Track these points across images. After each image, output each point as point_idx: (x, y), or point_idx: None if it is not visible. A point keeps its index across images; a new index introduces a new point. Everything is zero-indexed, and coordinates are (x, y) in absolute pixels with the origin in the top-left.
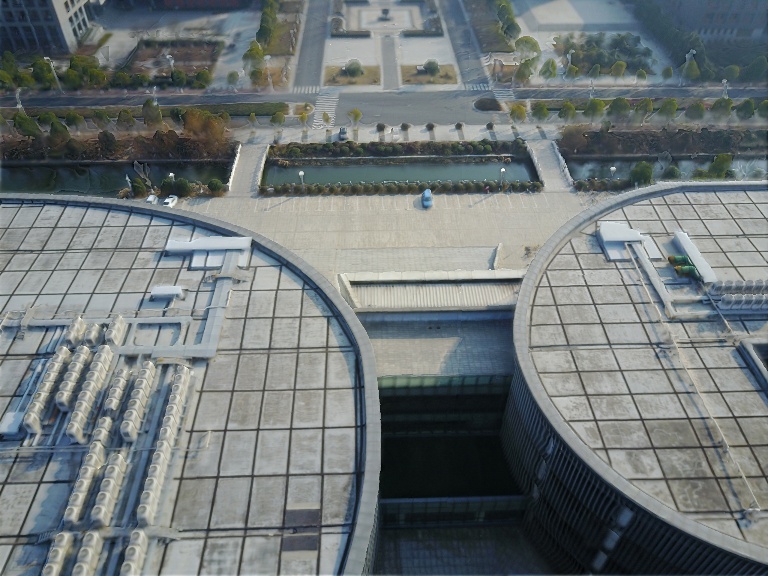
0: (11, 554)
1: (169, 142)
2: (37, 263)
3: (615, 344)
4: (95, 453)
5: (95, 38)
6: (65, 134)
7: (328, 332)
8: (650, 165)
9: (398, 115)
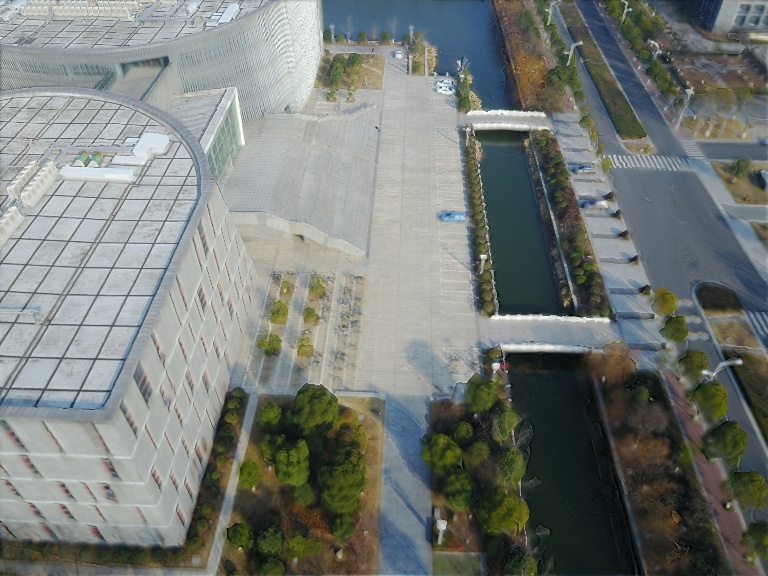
0: None
1: (524, 75)
2: None
3: None
4: None
5: (755, 37)
6: (532, 39)
7: None
8: (481, 389)
9: (651, 212)
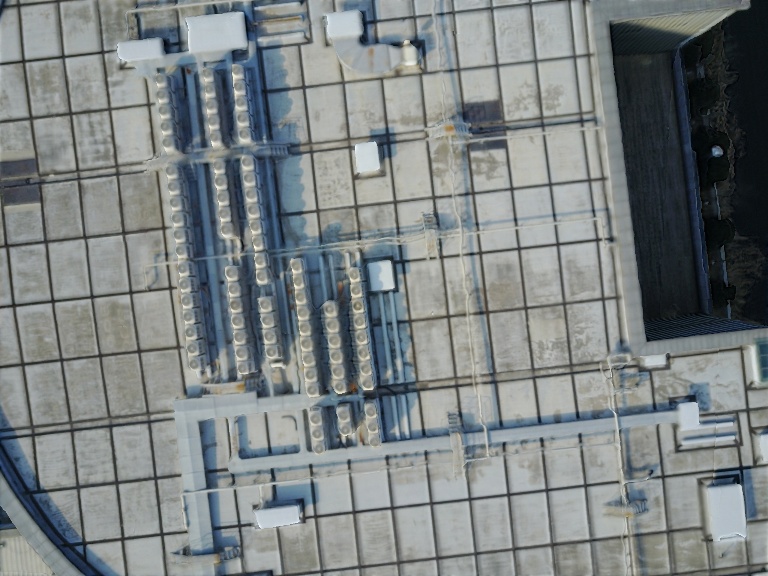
0: (308, 133)
1: None
2: (510, 568)
3: None
4: (253, 236)
5: None
6: None
7: (35, 462)
8: None
9: None
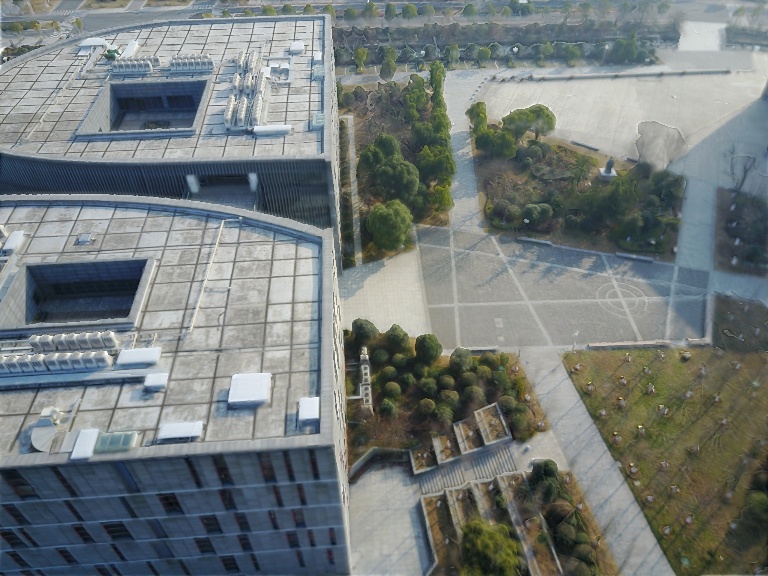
0: None
1: None
2: None
3: (34, 89)
4: None
5: None
6: None
7: None
8: None
9: None
